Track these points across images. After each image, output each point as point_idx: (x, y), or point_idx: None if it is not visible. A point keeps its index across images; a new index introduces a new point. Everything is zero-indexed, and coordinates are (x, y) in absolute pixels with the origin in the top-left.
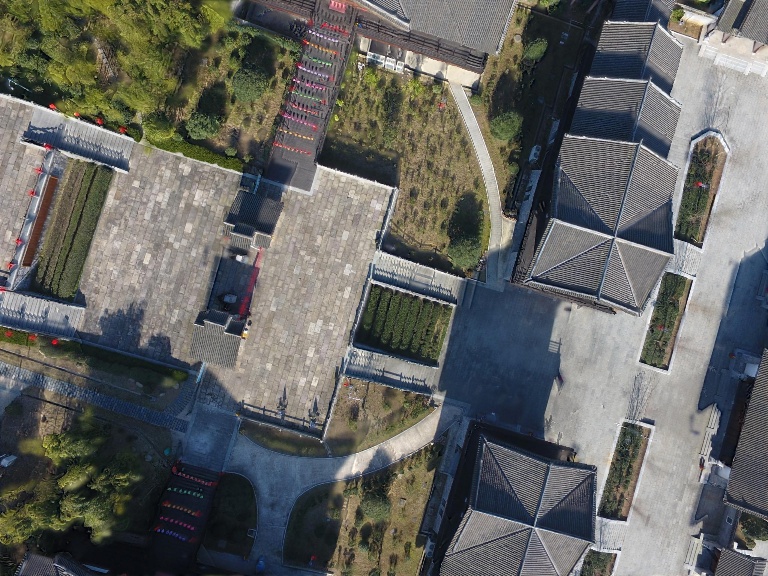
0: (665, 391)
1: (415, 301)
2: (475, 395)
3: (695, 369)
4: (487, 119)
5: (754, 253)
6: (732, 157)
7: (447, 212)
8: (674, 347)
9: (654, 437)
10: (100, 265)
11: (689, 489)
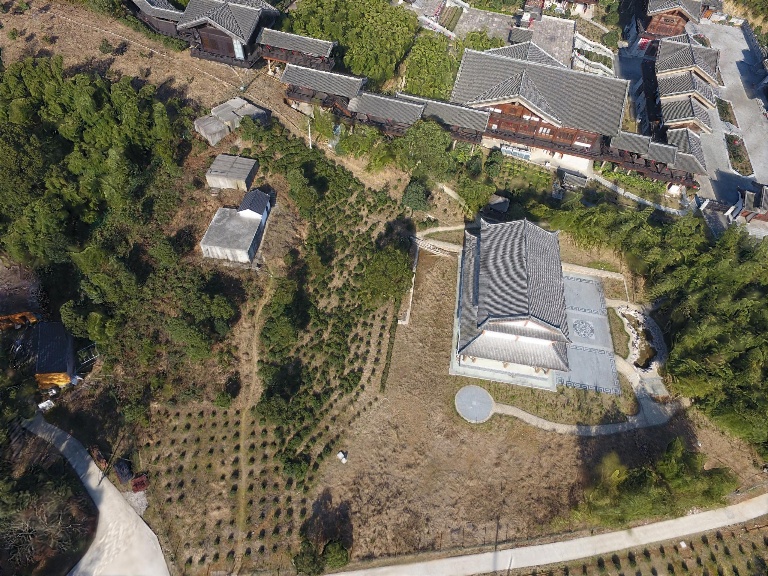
0: (728, 93)
1: (595, 52)
2: (635, 82)
3: (738, 88)
4: (601, 23)
5: (740, 61)
6: (711, 40)
7: (597, 36)
8: (723, 80)
9: (733, 105)
10: (460, 29)
11: (765, 122)
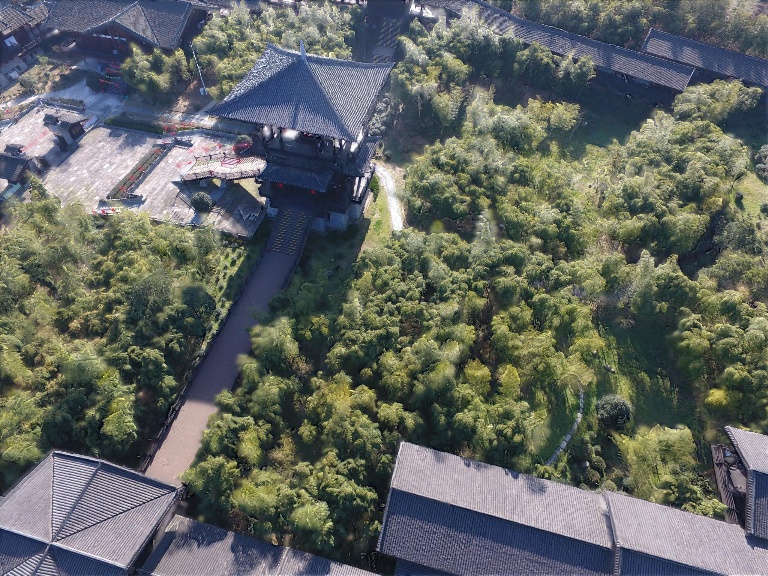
0: None
1: None
2: None
3: None
4: None
5: None
6: None
7: None
8: None
9: None
10: None
11: None
